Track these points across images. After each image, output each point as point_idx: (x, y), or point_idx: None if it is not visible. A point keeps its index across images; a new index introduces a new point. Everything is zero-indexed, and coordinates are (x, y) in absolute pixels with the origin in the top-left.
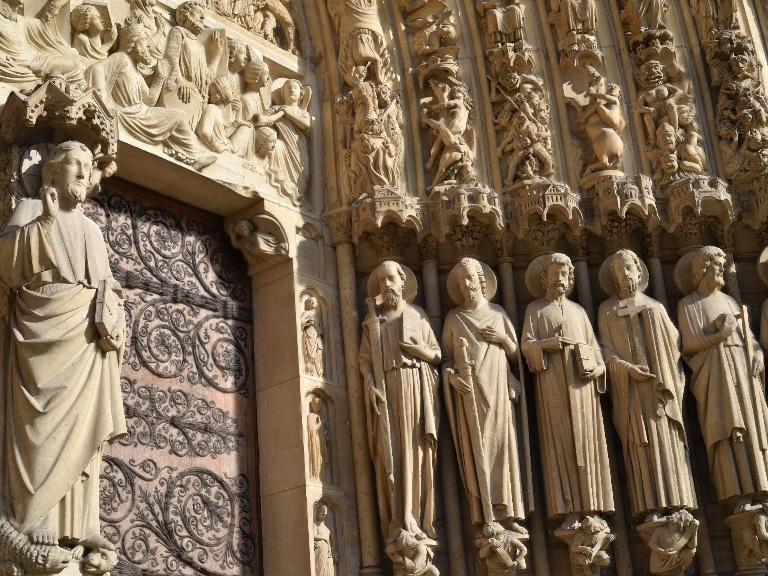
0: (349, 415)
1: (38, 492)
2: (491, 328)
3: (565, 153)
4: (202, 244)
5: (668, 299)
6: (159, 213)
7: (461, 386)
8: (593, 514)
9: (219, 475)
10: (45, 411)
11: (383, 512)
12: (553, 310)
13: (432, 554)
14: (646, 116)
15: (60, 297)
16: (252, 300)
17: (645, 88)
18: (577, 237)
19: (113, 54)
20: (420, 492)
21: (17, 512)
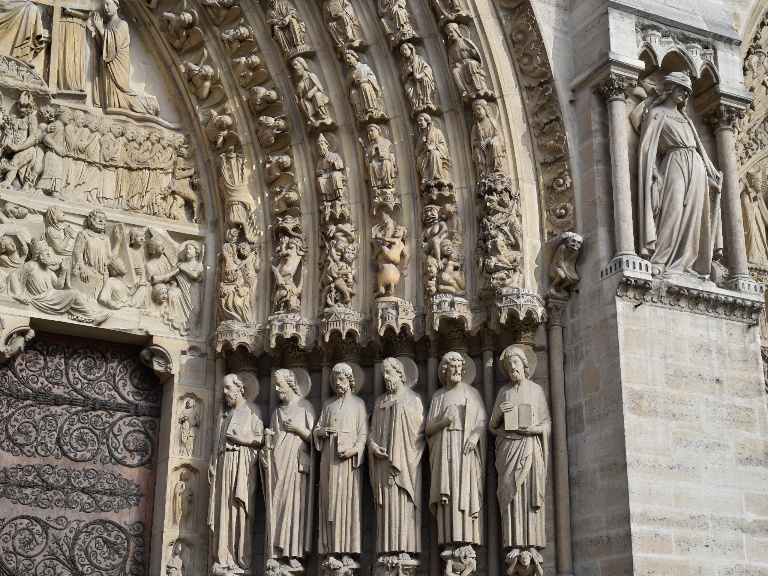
0: None
1: None
2: (290, 421)
3: (366, 282)
4: (123, 367)
5: None
6: (89, 351)
7: (263, 464)
8: (344, 555)
9: (120, 523)
10: None
11: None
12: (336, 405)
13: None
14: (421, 250)
15: None
16: (162, 401)
17: (427, 226)
18: (376, 345)
19: (24, 264)
20: (234, 537)
21: None
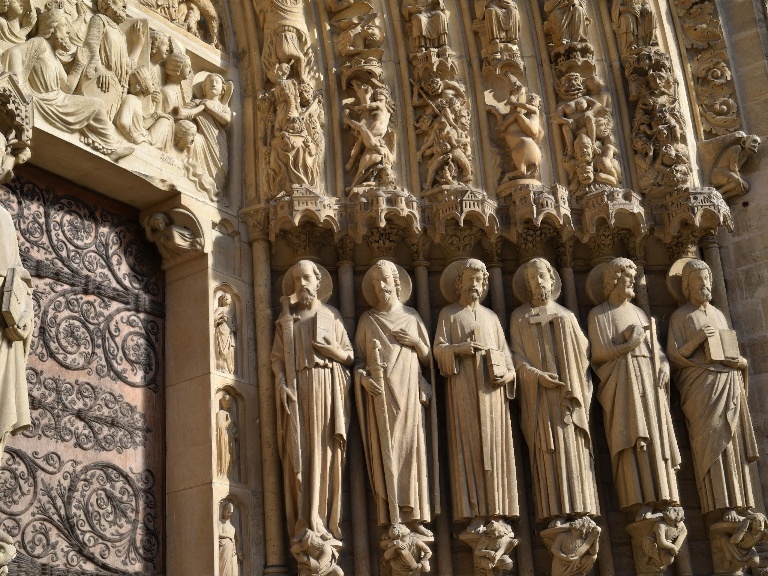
0: (259, 413)
1: None
2: (404, 331)
3: (484, 160)
4: (116, 236)
5: (579, 308)
6: (73, 202)
7: (372, 388)
8: (498, 518)
9: (124, 470)
10: None
11: (289, 511)
12: (466, 315)
13: (337, 555)
14: (565, 127)
15: None
16: (165, 294)
17: (565, 99)
18: (493, 244)
19: (31, 39)
20: (327, 492)
21: None
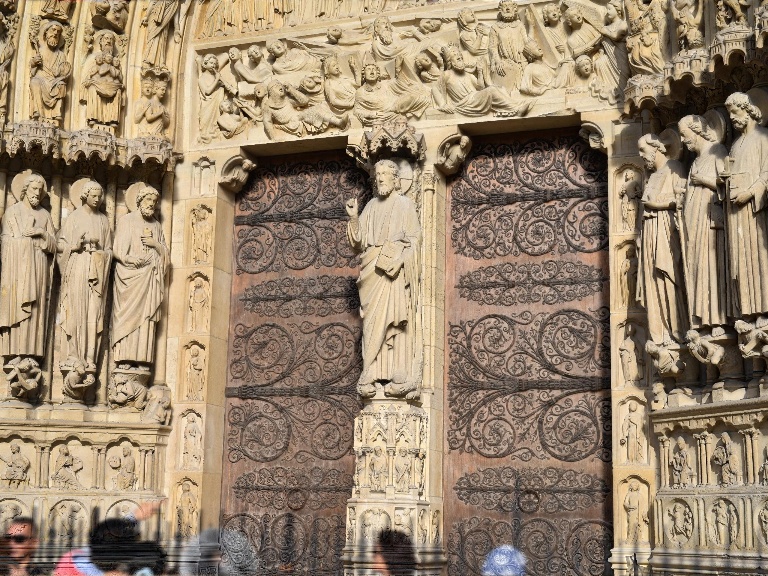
0: None
1: None
2: None
3: None
4: (572, 151)
5: None
6: (535, 143)
7: None
8: (757, 316)
9: (584, 311)
10: (363, 317)
11: None
12: (737, 144)
13: (675, 355)
14: None
15: (365, 256)
16: None
17: None
18: None
19: None
20: (665, 311)
21: None
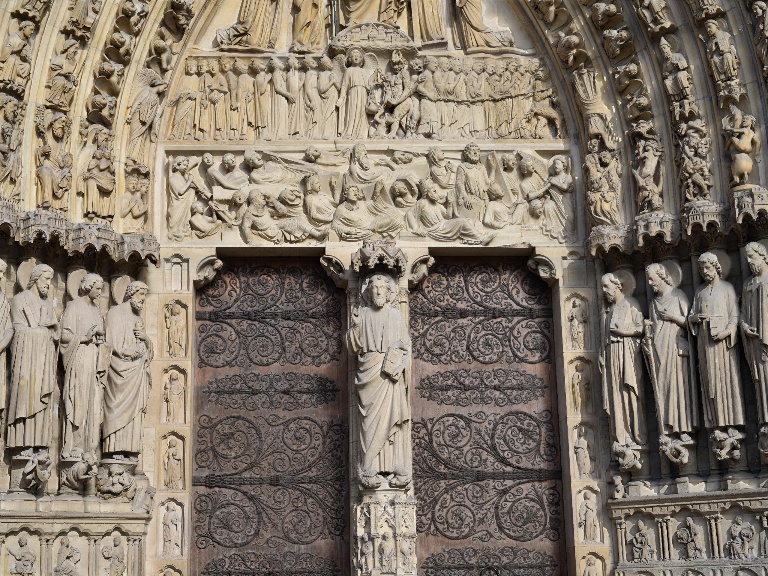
0: None
1: (367, 453)
2: (666, 310)
3: None
4: (514, 277)
5: None
6: (483, 267)
7: (645, 351)
8: (728, 427)
9: (530, 413)
10: (366, 416)
11: None
12: (706, 292)
13: (638, 455)
14: None
15: (368, 360)
16: (552, 302)
17: None
18: None
19: None
20: (628, 418)
21: (362, 461)
